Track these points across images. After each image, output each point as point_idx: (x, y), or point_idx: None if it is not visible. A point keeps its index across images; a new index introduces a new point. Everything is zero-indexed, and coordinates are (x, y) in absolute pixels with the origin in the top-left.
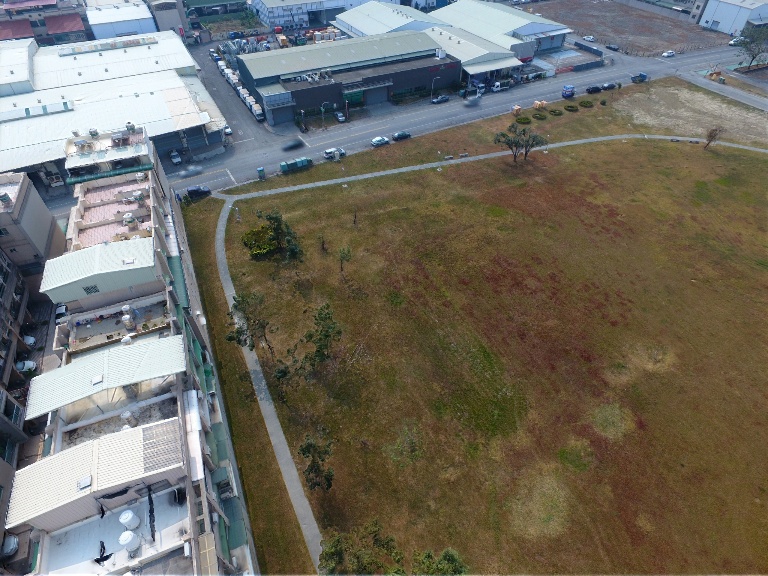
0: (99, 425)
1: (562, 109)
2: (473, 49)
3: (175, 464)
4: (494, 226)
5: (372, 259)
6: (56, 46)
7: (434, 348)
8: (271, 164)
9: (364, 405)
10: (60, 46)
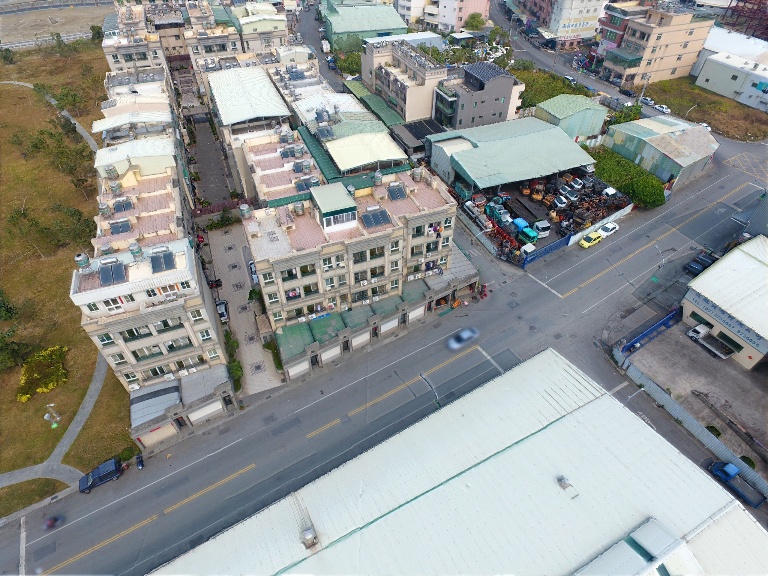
0: None
1: None
2: None
3: None
4: None
5: None
6: None
7: None
8: None
9: None
10: None
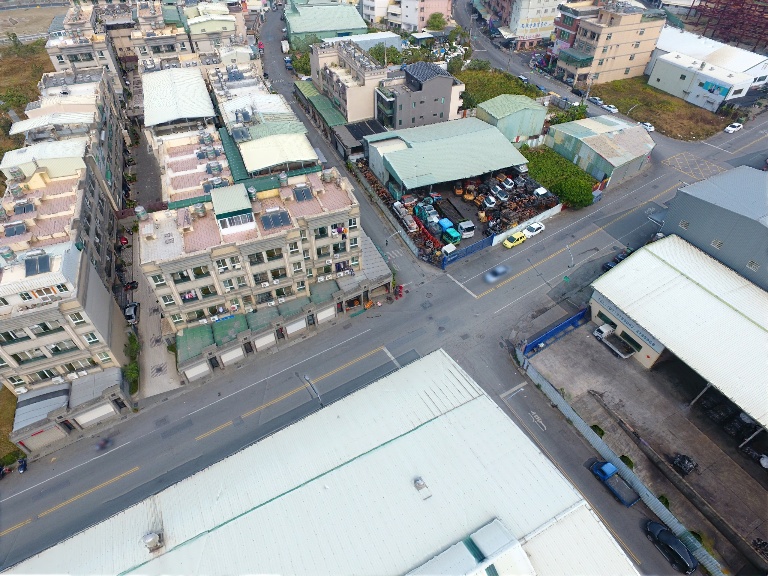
0: None
1: None
2: None
3: None
4: None
5: None
6: None
7: None
8: None
9: None
10: None
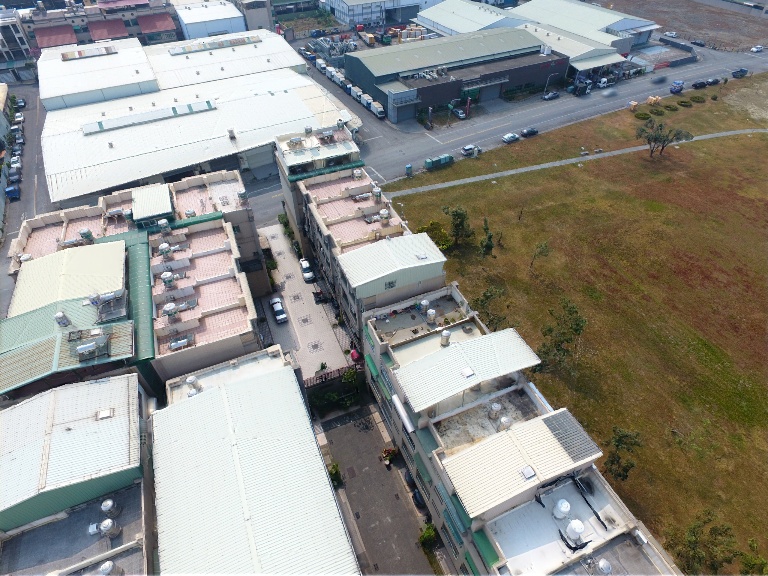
0: (460, 417)
1: (676, 104)
2: (576, 45)
3: (596, 454)
4: (658, 221)
5: (552, 254)
6: (157, 45)
7: (654, 341)
8: (412, 161)
9: (610, 398)
10: (161, 45)
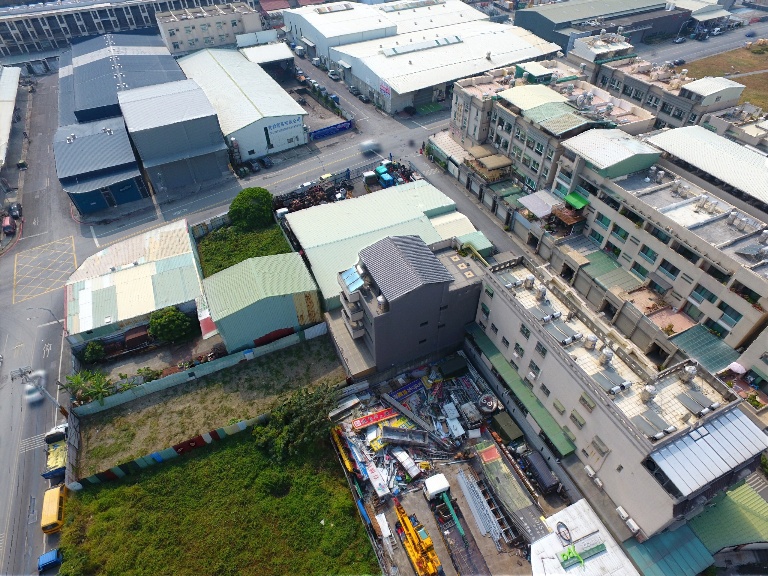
0: None
1: None
2: (693, 3)
3: None
4: None
5: None
6: None
7: None
8: None
9: None
10: None
